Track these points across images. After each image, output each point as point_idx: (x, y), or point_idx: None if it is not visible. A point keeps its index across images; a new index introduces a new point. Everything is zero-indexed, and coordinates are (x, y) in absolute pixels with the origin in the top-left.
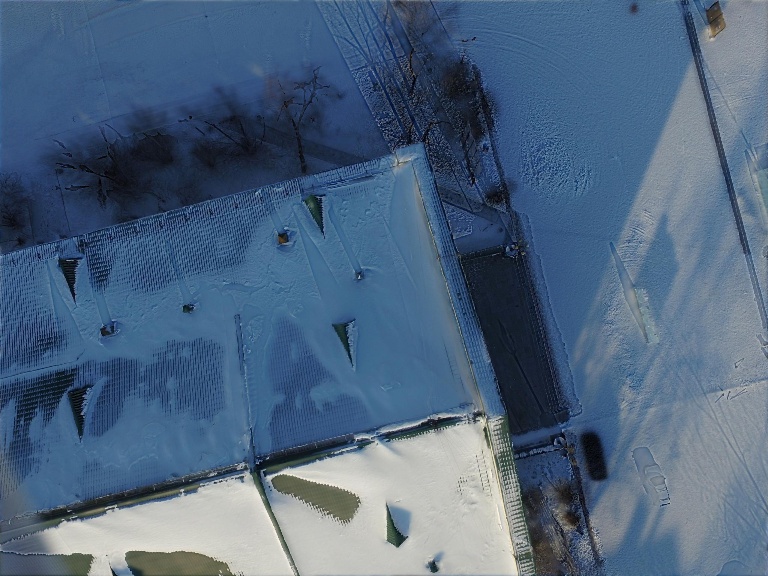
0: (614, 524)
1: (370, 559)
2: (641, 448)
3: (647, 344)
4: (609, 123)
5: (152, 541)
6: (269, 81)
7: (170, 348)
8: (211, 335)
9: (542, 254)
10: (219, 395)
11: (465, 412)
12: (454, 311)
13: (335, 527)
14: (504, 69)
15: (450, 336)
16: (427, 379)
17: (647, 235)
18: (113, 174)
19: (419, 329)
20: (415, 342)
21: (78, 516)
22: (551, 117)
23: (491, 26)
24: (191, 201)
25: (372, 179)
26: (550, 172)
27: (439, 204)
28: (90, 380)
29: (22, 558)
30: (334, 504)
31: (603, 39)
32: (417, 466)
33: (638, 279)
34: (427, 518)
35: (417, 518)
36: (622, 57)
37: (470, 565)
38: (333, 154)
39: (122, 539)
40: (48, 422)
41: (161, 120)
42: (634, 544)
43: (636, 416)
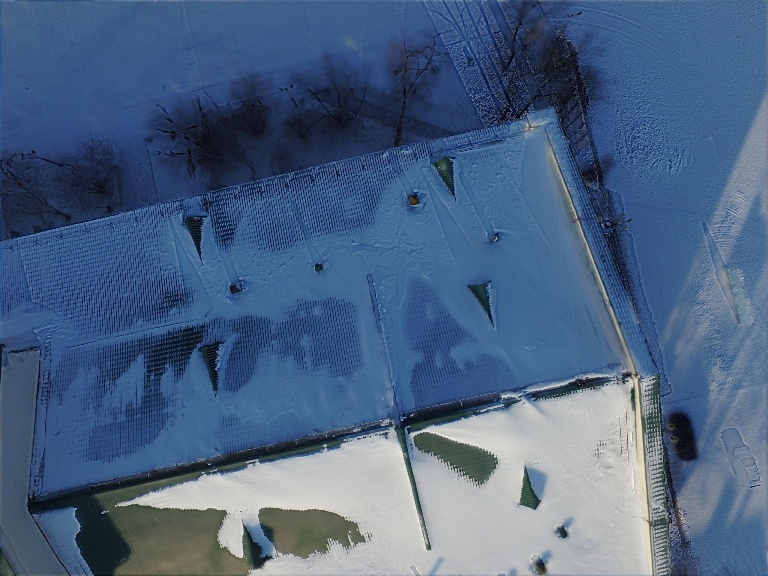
0: (701, 505)
1: (499, 523)
2: (730, 429)
3: (738, 325)
4: (704, 103)
5: (288, 498)
6: (362, 54)
7: (301, 307)
8: (343, 294)
9: (634, 233)
10: (356, 353)
11: (614, 372)
12: (597, 273)
13: (469, 488)
14: (600, 47)
15: (591, 298)
16: (572, 340)
17: (740, 216)
18: (204, 144)
19: (562, 290)
20: (555, 304)
21: (218, 470)
22: (646, 96)
23: (587, 4)
24: (284, 172)
25: (502, 143)
26: (644, 151)
27: (576, 168)
28: (220, 337)
29: (156, 512)
30: (472, 464)
31: (700, 19)
32: (560, 427)
33: (730, 260)
34: (562, 481)
35: (552, 481)
36: (718, 38)
37: (598, 531)
38: (425, 128)
39: (259, 495)
40: (180, 377)
41: (253, 91)
42: (721, 526)
43: (726, 397)
